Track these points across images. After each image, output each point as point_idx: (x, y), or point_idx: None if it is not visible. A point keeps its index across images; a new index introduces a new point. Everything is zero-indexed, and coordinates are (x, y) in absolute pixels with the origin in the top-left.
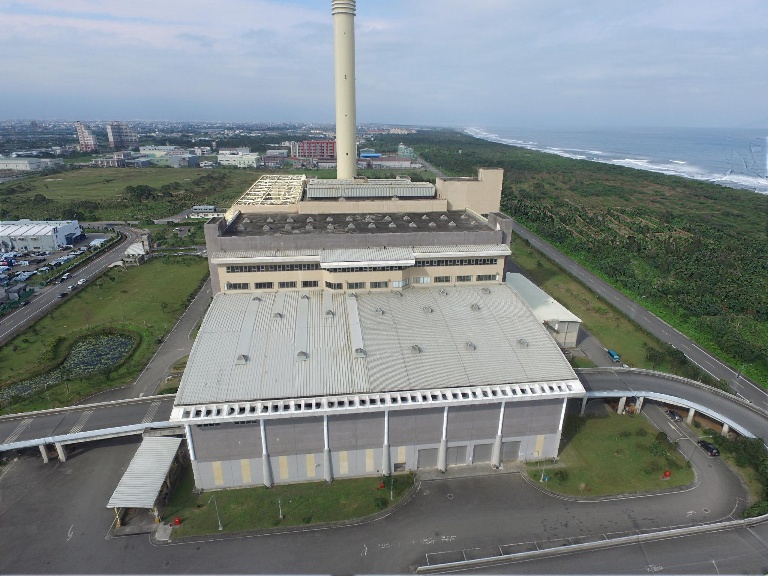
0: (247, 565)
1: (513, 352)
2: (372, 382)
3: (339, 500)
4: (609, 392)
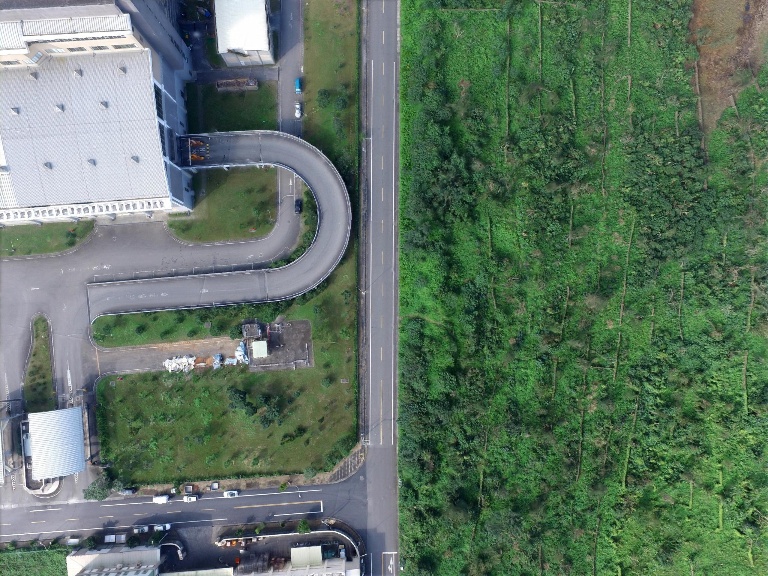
0: (1, 278)
1: (126, 169)
2: (19, 198)
3: (46, 240)
4: (238, 165)
